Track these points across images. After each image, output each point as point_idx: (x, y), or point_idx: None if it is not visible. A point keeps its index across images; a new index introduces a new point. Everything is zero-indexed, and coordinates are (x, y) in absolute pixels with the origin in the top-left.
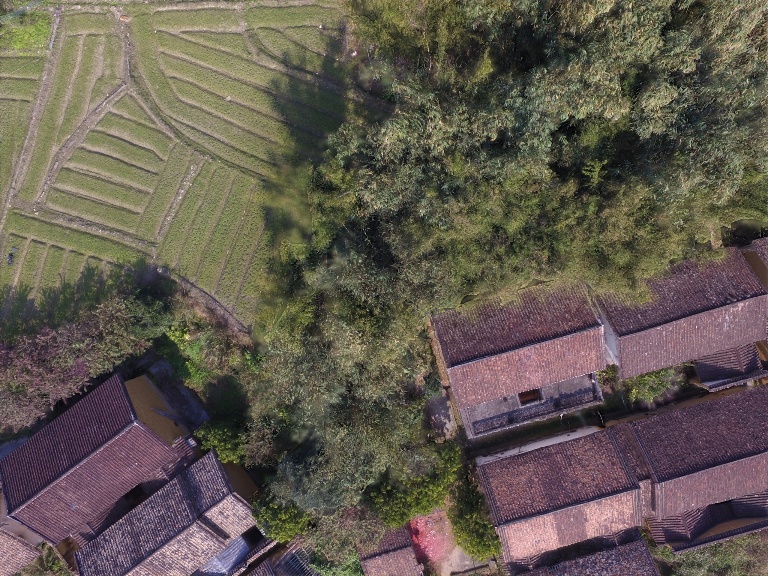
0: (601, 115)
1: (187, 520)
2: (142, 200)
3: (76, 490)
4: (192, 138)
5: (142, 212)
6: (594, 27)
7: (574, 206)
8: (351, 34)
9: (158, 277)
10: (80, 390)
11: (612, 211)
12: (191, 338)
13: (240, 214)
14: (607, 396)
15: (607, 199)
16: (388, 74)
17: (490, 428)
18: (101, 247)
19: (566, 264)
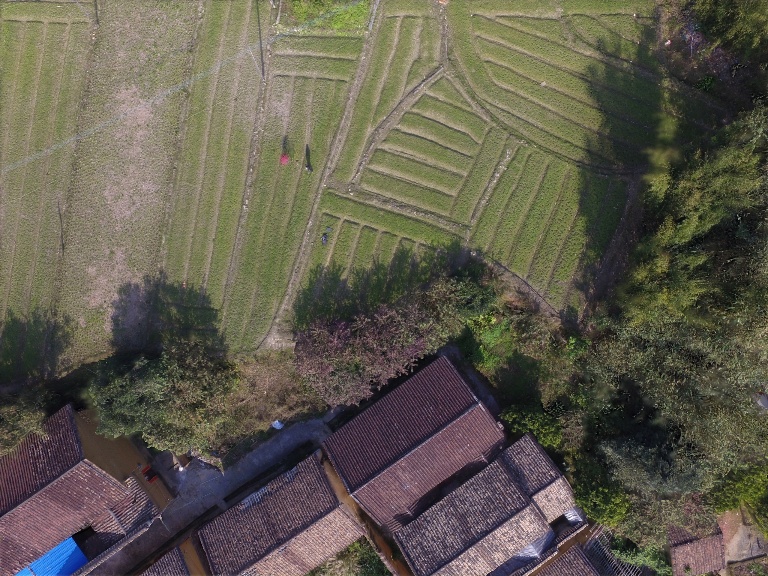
0: None
1: (520, 502)
2: (457, 183)
3: (412, 470)
4: (506, 122)
5: (456, 195)
6: None
7: None
8: (665, 23)
9: (468, 260)
10: (409, 370)
11: None
12: (495, 322)
13: (554, 199)
14: None
15: None
16: (704, 64)
17: None
18: (416, 229)
19: None
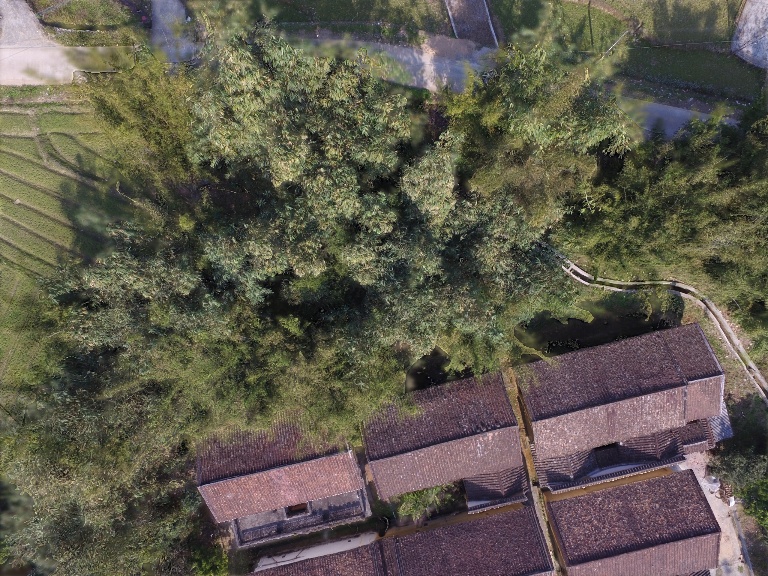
0: (294, 273)
1: None
2: None
3: None
4: None
5: None
6: (300, 182)
7: (280, 354)
8: None
9: None
10: None
11: (298, 369)
12: None
13: (23, 316)
14: (386, 505)
15: (313, 348)
16: None
17: (259, 537)
18: None
19: (255, 418)
